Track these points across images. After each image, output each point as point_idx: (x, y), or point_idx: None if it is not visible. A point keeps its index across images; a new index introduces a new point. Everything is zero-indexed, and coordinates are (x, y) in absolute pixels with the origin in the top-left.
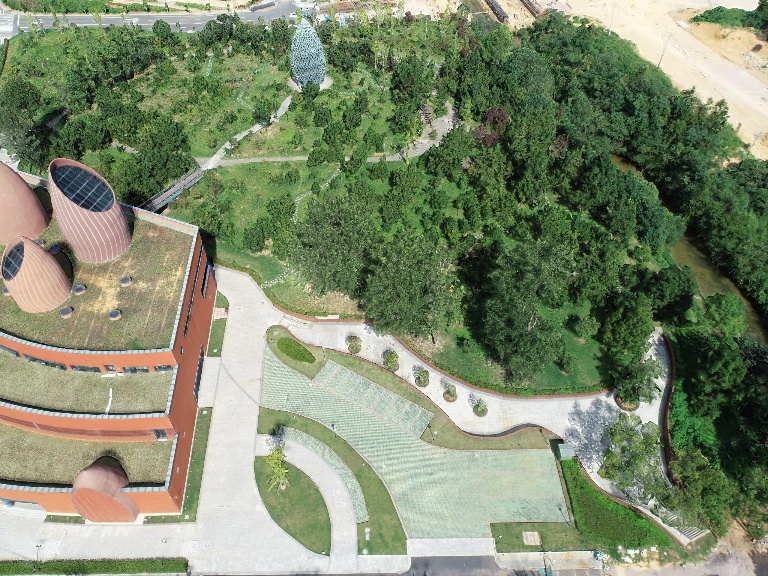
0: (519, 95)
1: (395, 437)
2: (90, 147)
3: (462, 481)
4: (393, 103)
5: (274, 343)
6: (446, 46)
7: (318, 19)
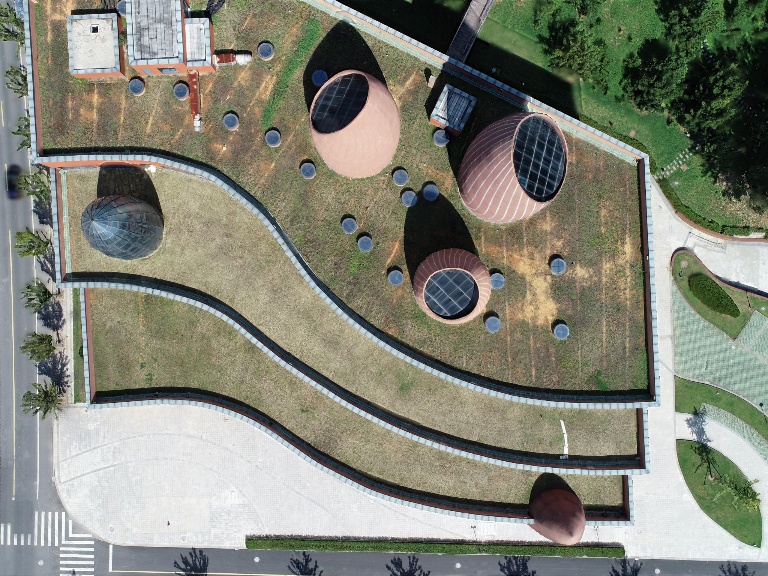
0: None
1: None
2: None
3: None
4: None
5: (684, 281)
6: None
7: None
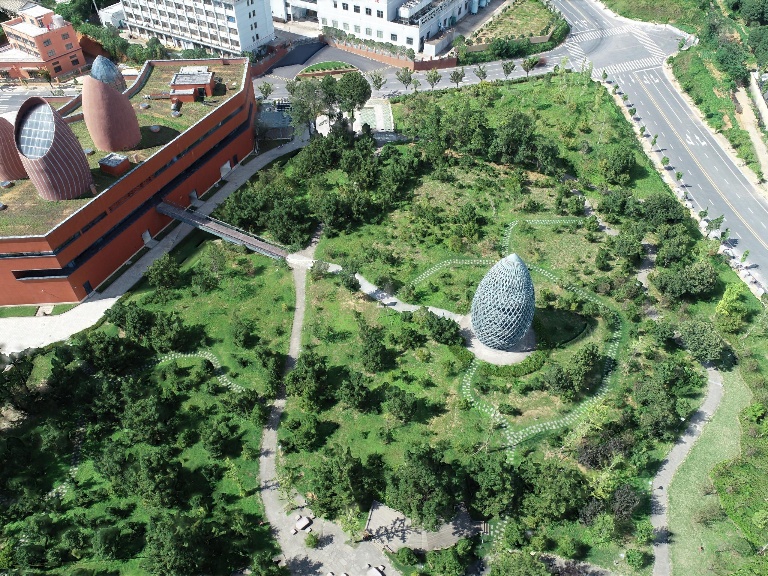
0: None
1: None
2: None
3: None
4: None
5: None
6: None
7: None
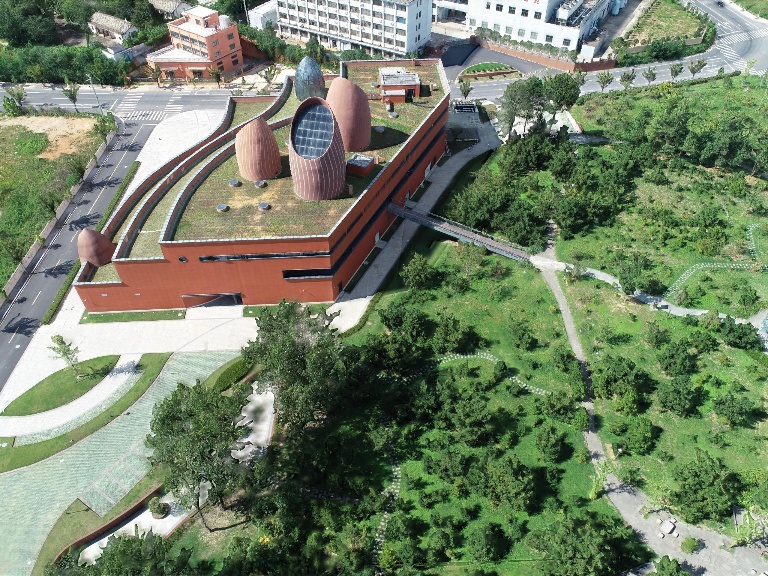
0: None
1: (90, 472)
2: (550, 169)
3: (7, 541)
4: None
5: None
6: None
7: None
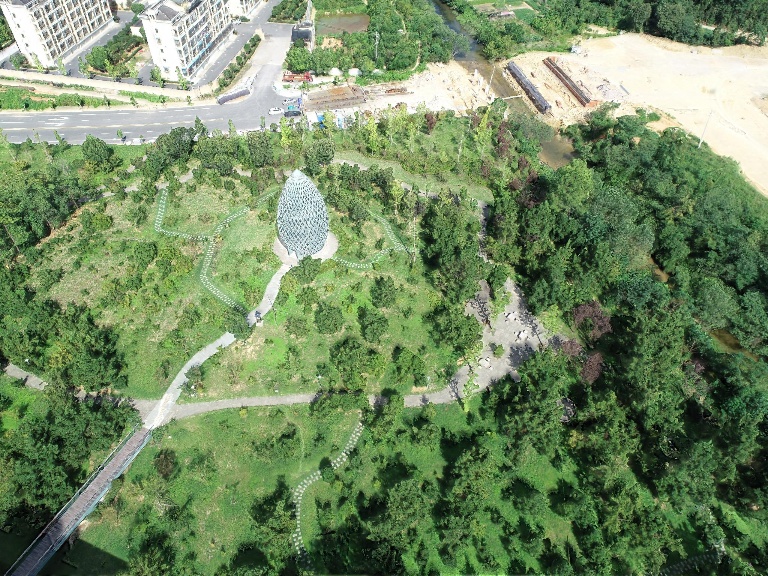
0: (613, 272)
1: None
2: None
3: None
4: (429, 283)
5: None
6: (488, 172)
7: (308, 120)
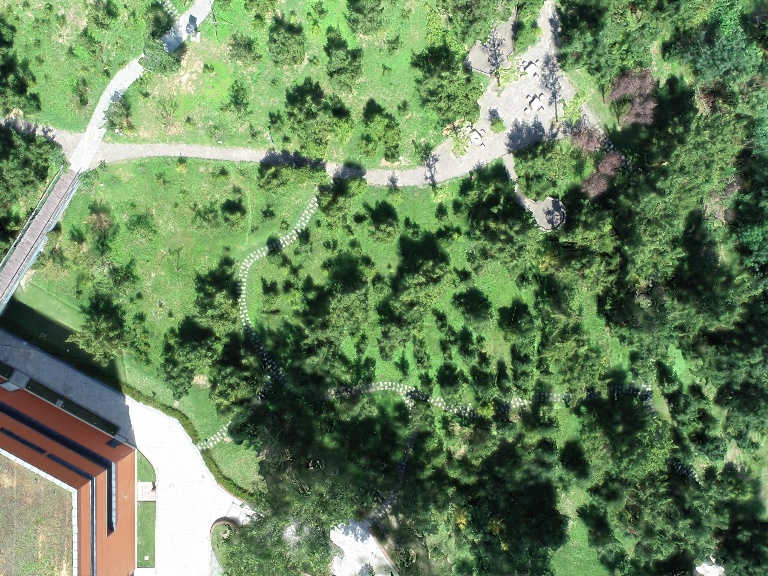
0: (697, 17)
1: None
2: None
3: None
4: None
5: (221, 552)
6: None
7: None
